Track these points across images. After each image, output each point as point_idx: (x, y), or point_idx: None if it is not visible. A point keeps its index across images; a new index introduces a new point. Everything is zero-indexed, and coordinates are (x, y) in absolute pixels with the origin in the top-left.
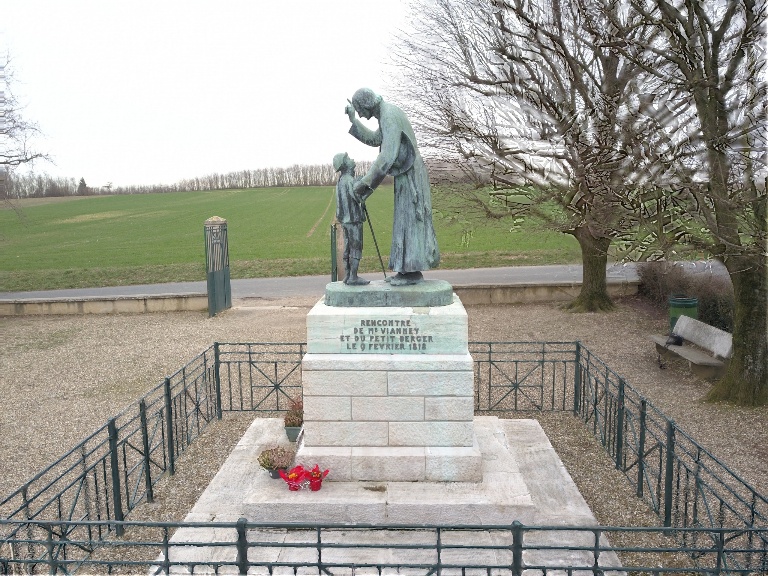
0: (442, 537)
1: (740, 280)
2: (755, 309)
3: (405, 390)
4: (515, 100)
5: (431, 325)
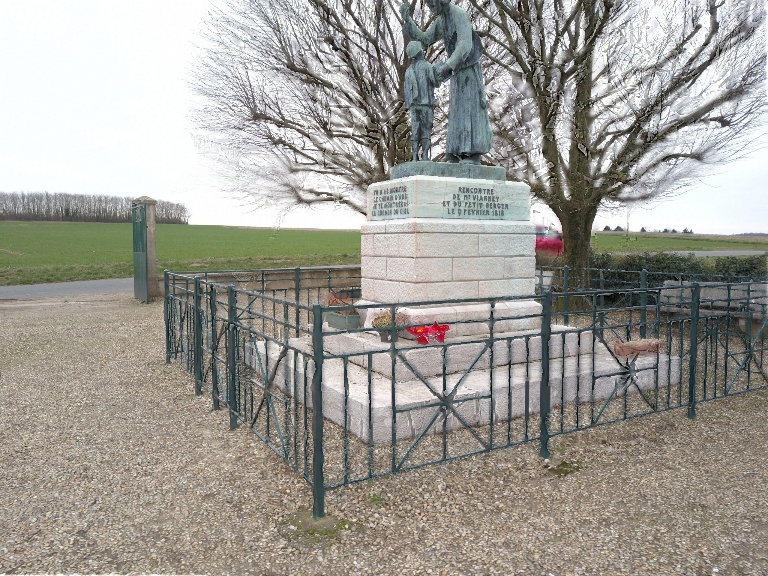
0: (552, 362)
1: (568, 221)
2: (579, 242)
3: (492, 251)
4: (356, 83)
5: (507, 194)
